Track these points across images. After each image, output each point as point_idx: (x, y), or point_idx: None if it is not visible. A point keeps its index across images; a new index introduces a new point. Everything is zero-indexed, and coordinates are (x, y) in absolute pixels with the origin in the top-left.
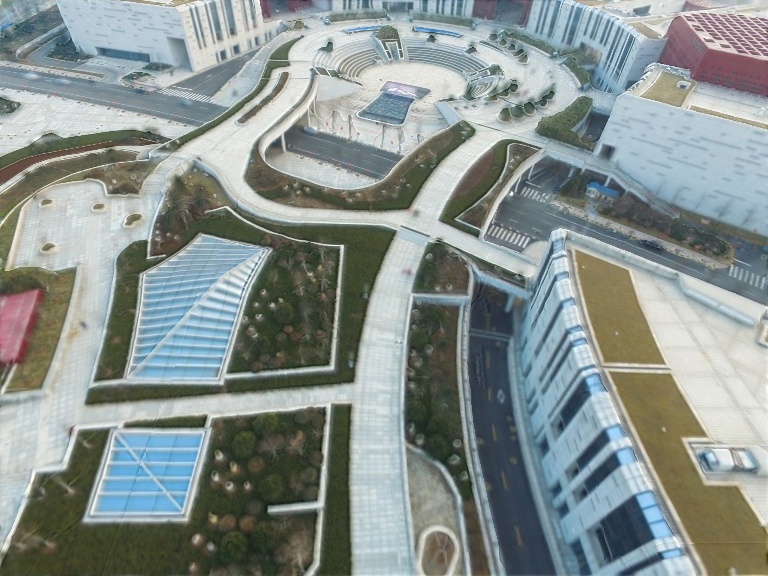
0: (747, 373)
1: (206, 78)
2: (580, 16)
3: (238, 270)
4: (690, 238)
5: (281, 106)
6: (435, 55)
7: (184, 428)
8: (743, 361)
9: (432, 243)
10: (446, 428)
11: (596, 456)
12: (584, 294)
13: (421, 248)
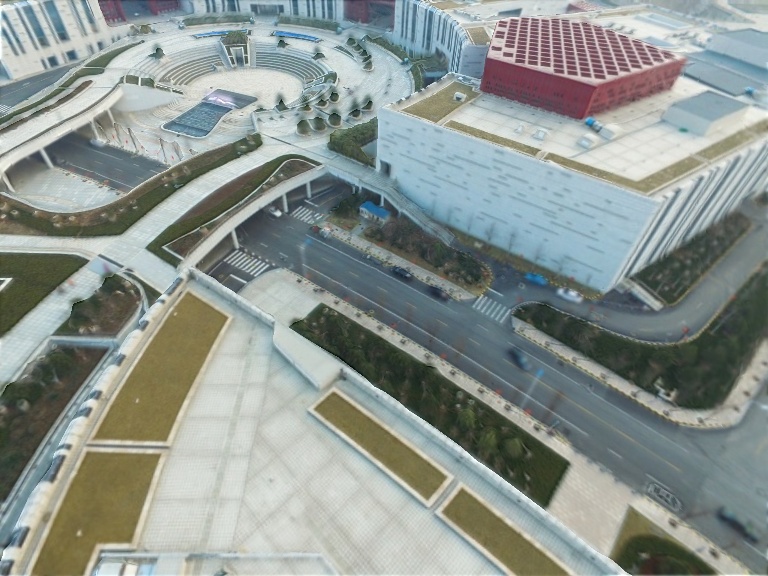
0: (263, 451)
1: (21, 86)
2: (432, 20)
3: None
4: (447, 264)
5: (53, 118)
6: (283, 61)
7: None
8: (271, 435)
9: (118, 275)
10: None
11: None
12: (147, 349)
13: (103, 281)
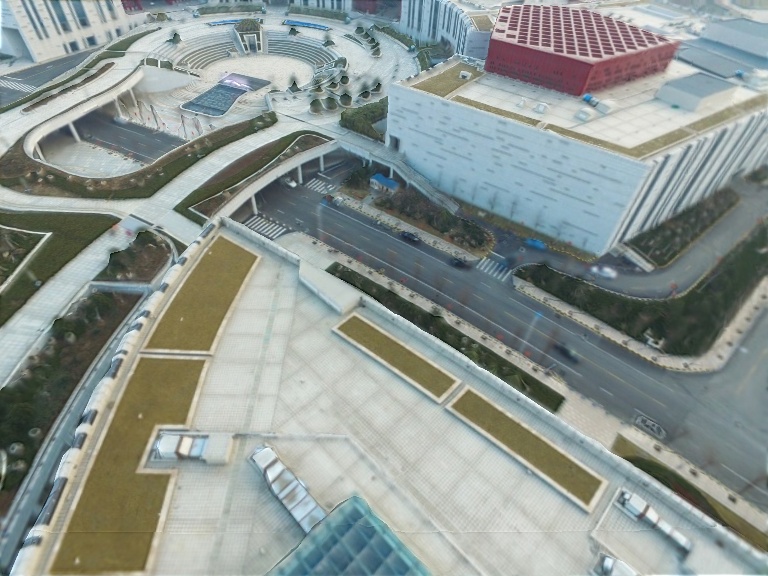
0: (294, 360)
1: (44, 69)
2: (438, 9)
3: None
4: (453, 230)
5: (80, 95)
6: (295, 48)
7: None
8: (301, 348)
9: None
10: (24, 416)
11: None
12: (187, 280)
13: (135, 237)
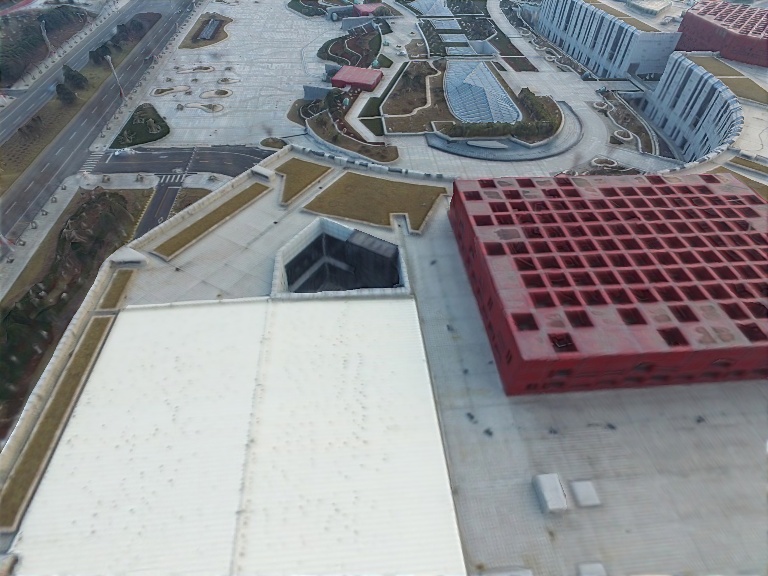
0: None
1: None
2: None
3: (441, 1)
4: None
5: None
6: None
7: (449, 20)
8: None
9: None
10: None
11: (563, 6)
12: None
13: (498, 2)
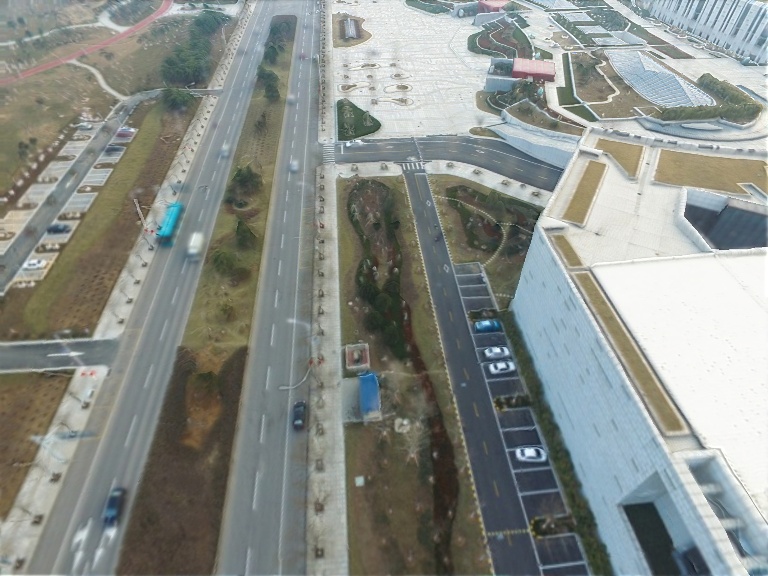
0: None
1: None
2: None
3: None
4: None
5: None
6: None
7: None
8: None
9: None
10: None
11: None
12: None
13: None
